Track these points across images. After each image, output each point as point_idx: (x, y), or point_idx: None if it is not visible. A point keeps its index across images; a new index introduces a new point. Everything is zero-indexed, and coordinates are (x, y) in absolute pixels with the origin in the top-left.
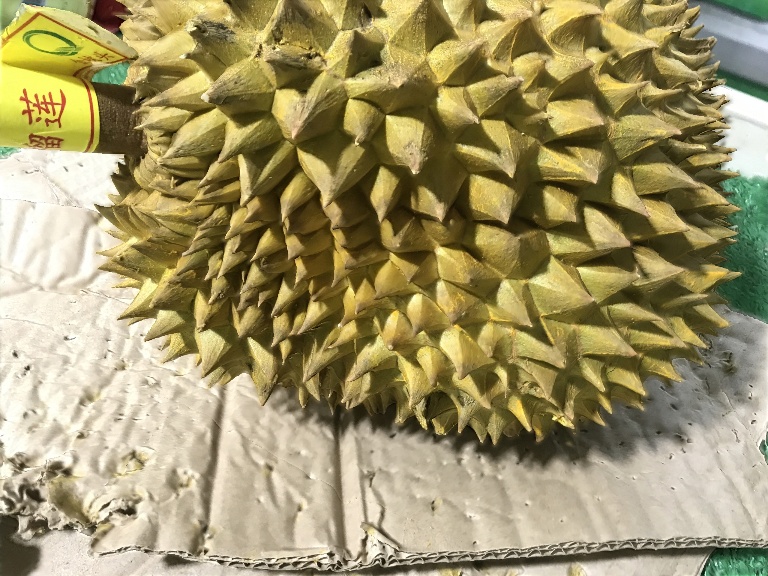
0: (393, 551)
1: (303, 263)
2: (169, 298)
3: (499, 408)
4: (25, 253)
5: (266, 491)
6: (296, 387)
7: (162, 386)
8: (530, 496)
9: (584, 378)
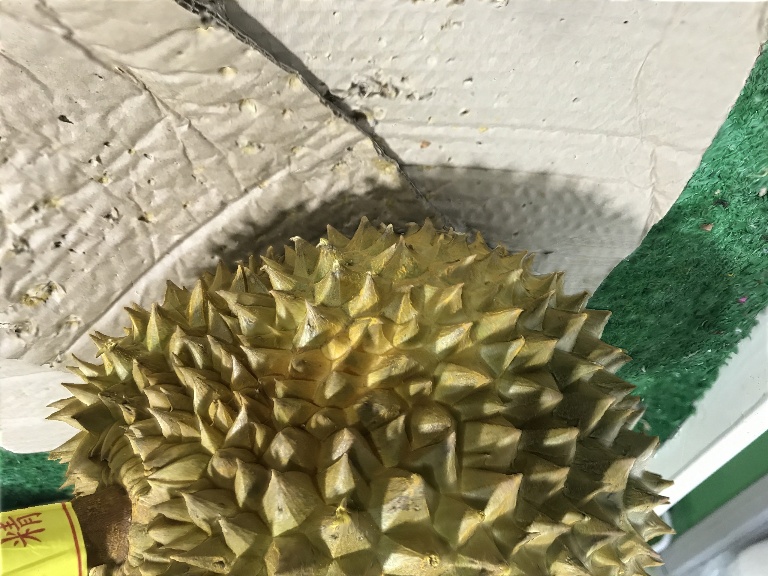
0: None
1: None
2: None
3: None
4: (68, 1)
5: None
6: None
7: (120, 222)
8: None
9: None
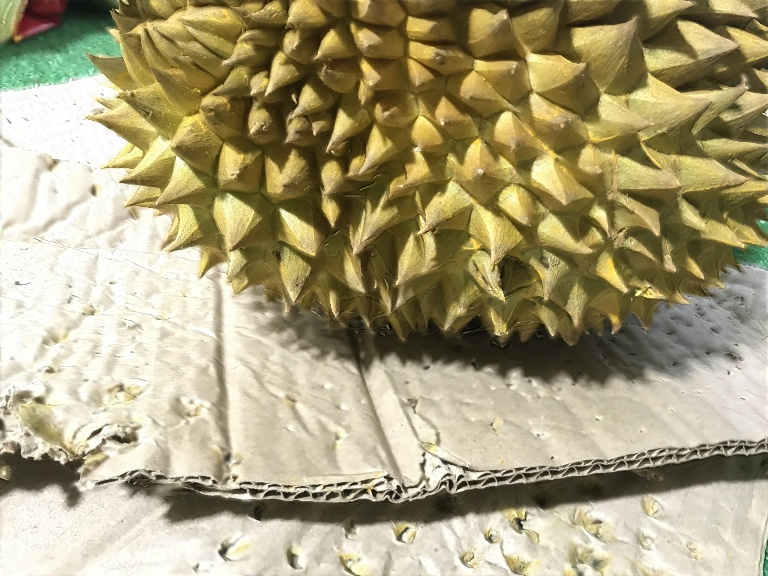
0: (462, 470)
1: (374, 69)
2: (192, 143)
3: (582, 277)
4: None
5: (294, 420)
6: (304, 328)
7: (144, 329)
8: (598, 411)
9: (683, 224)
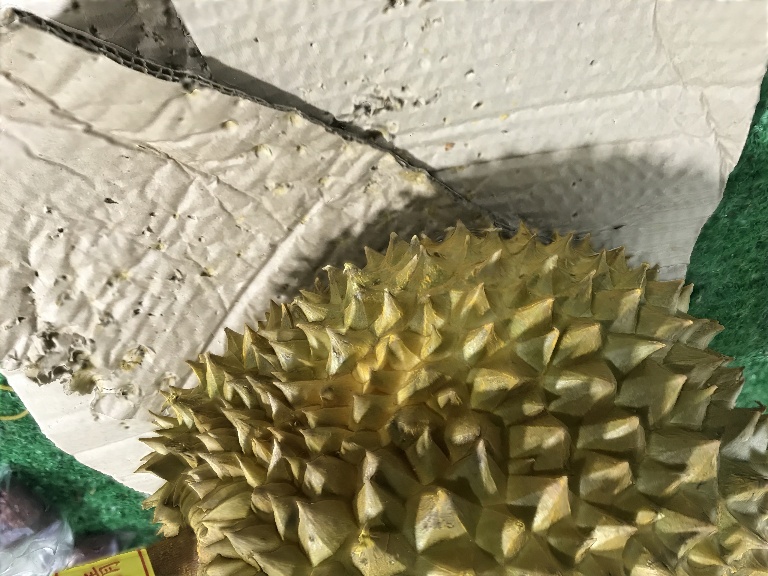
0: None
1: None
2: None
3: None
4: (72, 100)
5: None
6: None
7: (186, 281)
8: None
9: None
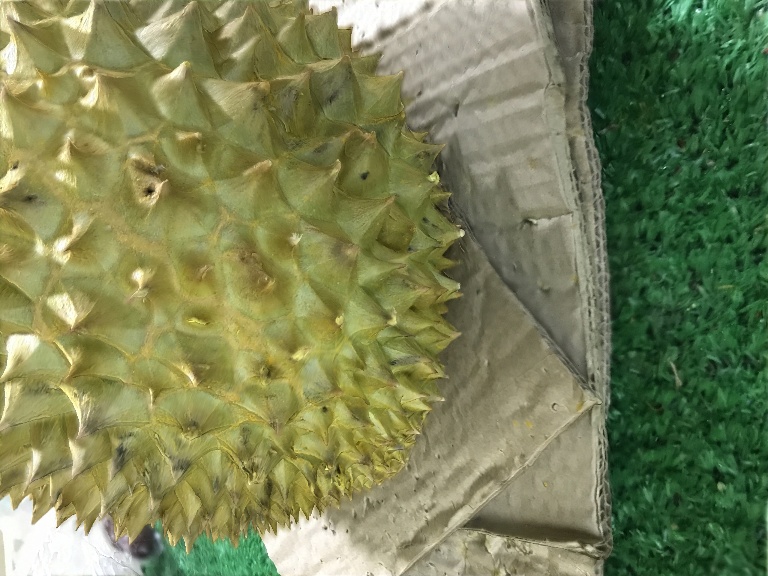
0: None
1: None
2: None
3: None
4: None
5: None
6: None
7: None
8: None
9: None
